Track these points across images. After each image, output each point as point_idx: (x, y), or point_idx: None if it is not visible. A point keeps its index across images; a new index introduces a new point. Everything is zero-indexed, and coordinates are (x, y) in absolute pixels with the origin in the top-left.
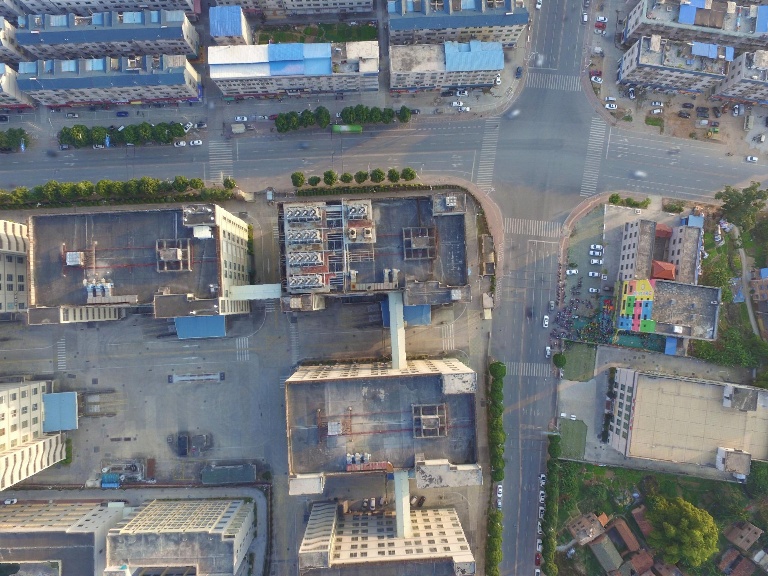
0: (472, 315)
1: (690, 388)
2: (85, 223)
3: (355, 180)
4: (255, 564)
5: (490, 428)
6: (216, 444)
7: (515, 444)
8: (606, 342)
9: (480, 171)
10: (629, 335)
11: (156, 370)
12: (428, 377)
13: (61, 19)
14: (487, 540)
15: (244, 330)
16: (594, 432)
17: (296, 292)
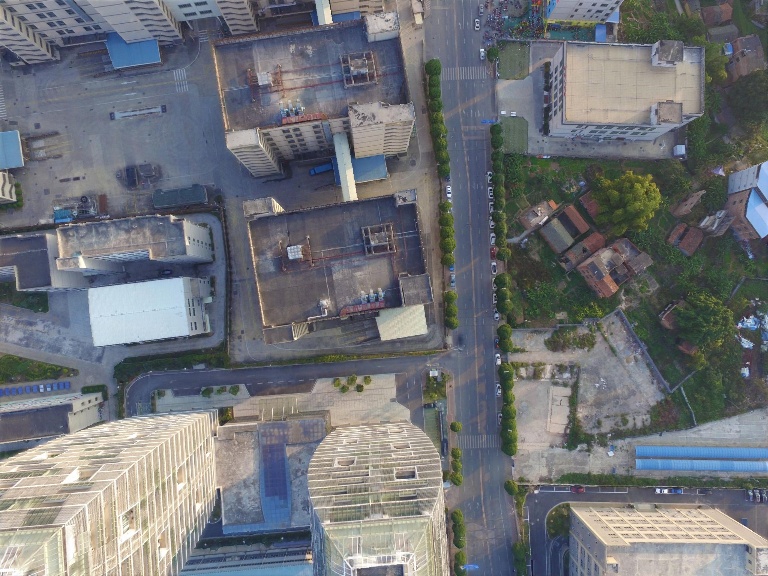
0: (404, 26)
1: (619, 52)
2: None
3: None
4: (217, 287)
5: (431, 124)
6: (165, 175)
7: (459, 146)
8: (538, 38)
9: None
10: (560, 30)
11: (97, 109)
12: (353, 30)
13: None
14: (440, 232)
15: (180, 62)
16: (535, 127)
17: None
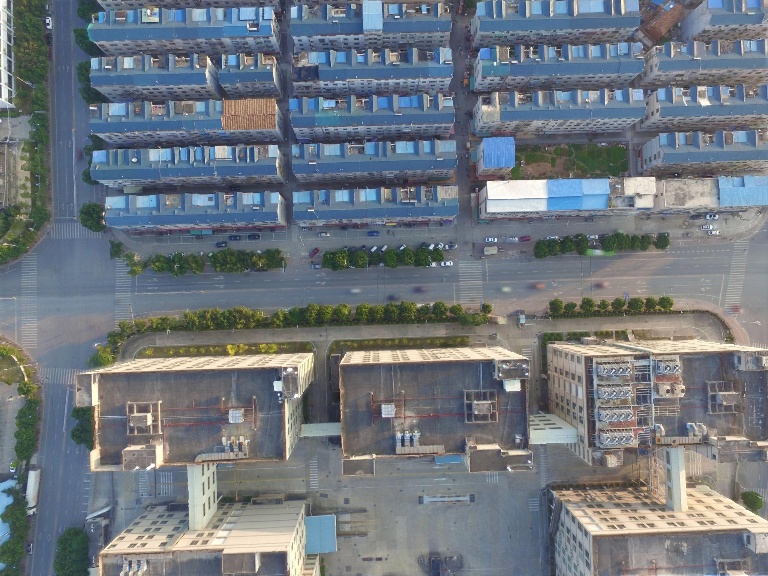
0: None
1: None
2: (391, 372)
3: (611, 307)
4: None
5: None
6: (466, 565)
7: None
8: None
9: (728, 295)
10: None
11: (407, 491)
12: None
13: (334, 148)
14: None
15: None
16: None
17: (605, 447)
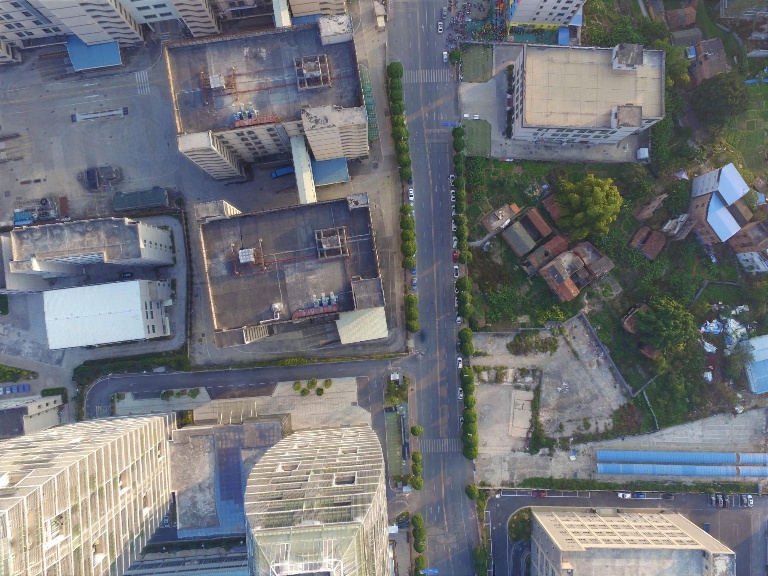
0: (367, 29)
1: (579, 55)
2: None
3: None
4: (178, 290)
5: (392, 127)
6: (126, 177)
7: (422, 149)
8: (501, 41)
9: None
10: (523, 33)
11: (58, 111)
12: (307, 33)
13: None
14: (401, 235)
15: (142, 64)
16: (498, 130)
17: None
